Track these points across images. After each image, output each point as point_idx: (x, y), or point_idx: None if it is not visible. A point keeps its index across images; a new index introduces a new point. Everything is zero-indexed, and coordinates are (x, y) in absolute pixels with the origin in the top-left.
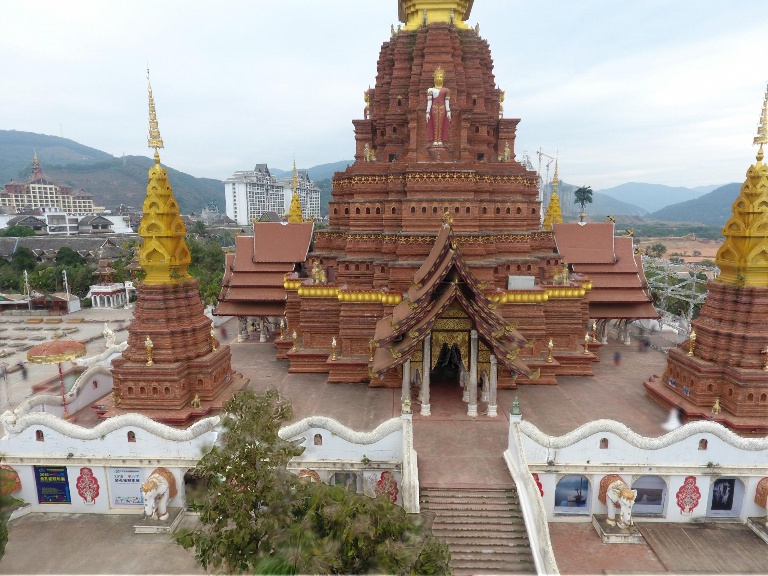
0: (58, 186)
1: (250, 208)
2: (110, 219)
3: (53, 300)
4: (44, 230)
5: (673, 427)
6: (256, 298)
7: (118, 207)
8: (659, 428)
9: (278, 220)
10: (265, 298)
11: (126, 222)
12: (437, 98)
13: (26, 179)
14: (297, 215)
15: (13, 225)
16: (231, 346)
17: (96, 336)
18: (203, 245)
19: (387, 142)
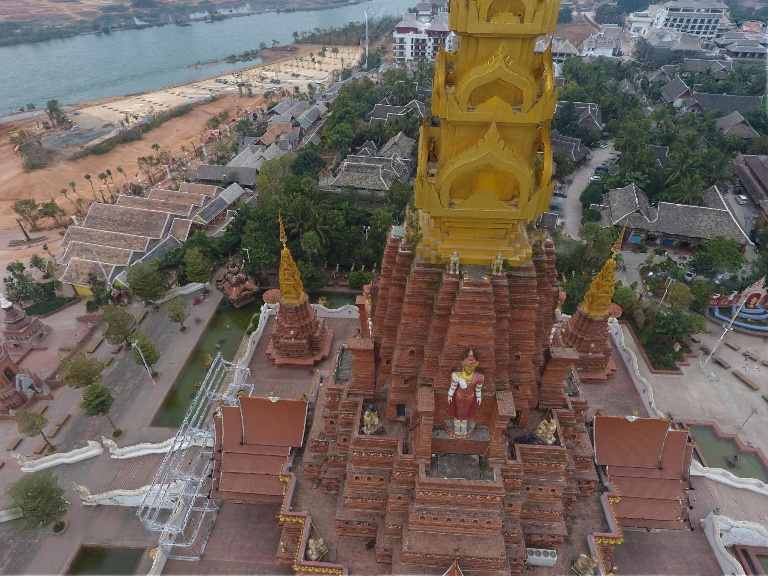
0: None
1: None
2: None
3: None
4: None
5: (340, 336)
6: None
7: None
8: (347, 335)
9: None
10: None
11: None
12: None
13: None
14: None
15: None
16: None
17: None
18: None
19: None
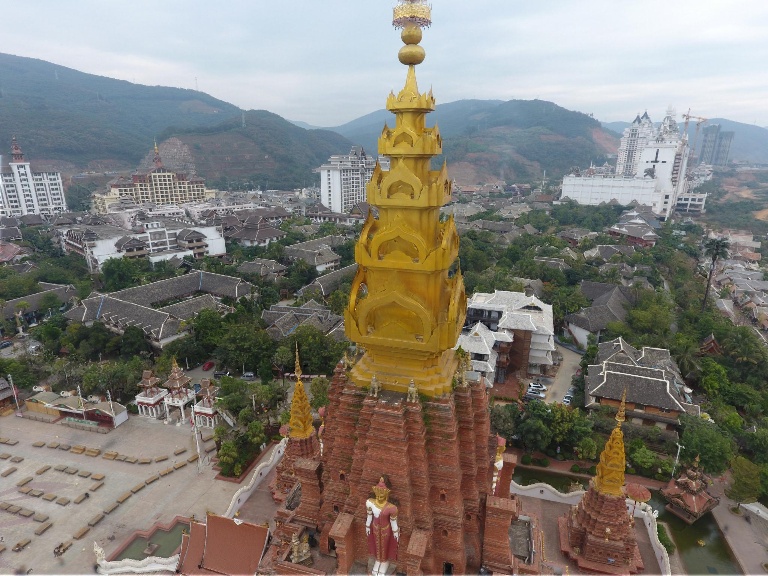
0: (175, 173)
1: (344, 195)
2: (204, 230)
3: (102, 414)
4: (146, 249)
5: None
6: None
7: (212, 218)
8: None
9: None
10: None
11: (219, 232)
12: (377, 519)
13: (149, 168)
14: (300, 406)
15: (120, 247)
16: None
17: (109, 510)
18: (251, 333)
19: (327, 520)
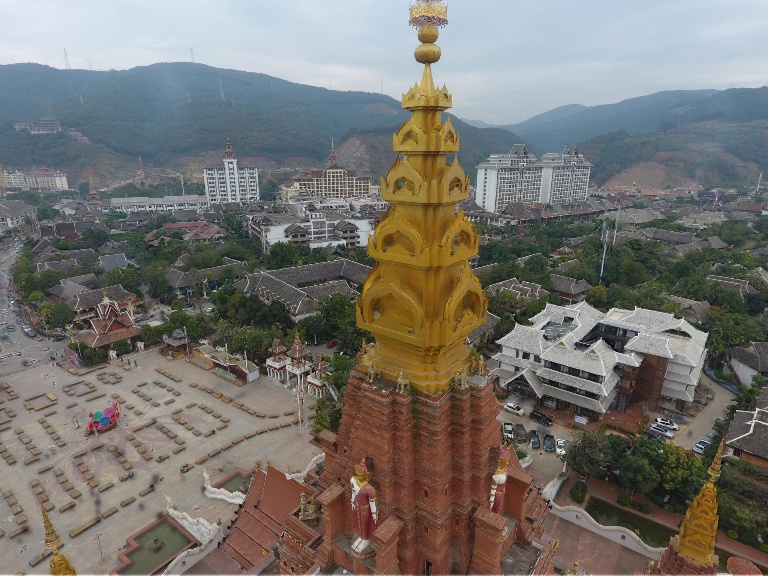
0: (346, 170)
1: (499, 195)
2: (358, 223)
3: (240, 370)
4: (307, 236)
5: None
6: (244, 554)
7: (366, 211)
8: None
9: (523, 212)
10: (250, 559)
11: (371, 225)
12: (357, 496)
13: (325, 165)
14: None
15: (287, 233)
16: (234, 575)
17: (225, 447)
18: None
19: None
